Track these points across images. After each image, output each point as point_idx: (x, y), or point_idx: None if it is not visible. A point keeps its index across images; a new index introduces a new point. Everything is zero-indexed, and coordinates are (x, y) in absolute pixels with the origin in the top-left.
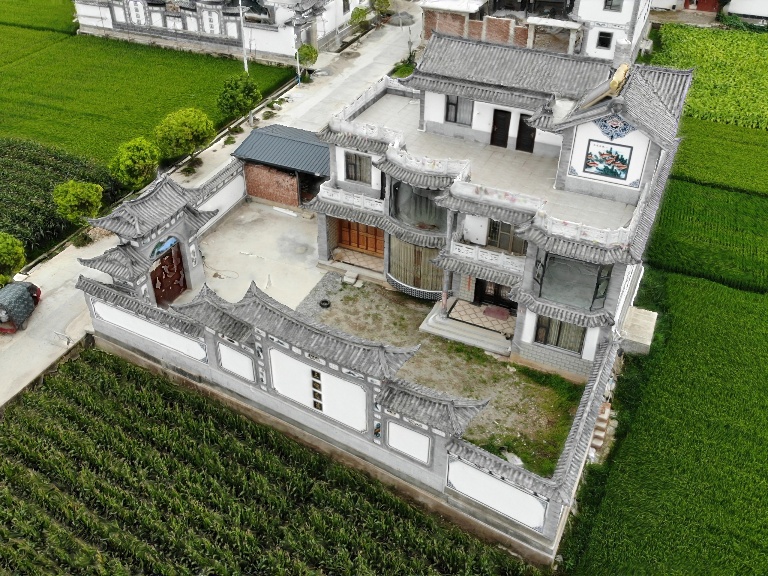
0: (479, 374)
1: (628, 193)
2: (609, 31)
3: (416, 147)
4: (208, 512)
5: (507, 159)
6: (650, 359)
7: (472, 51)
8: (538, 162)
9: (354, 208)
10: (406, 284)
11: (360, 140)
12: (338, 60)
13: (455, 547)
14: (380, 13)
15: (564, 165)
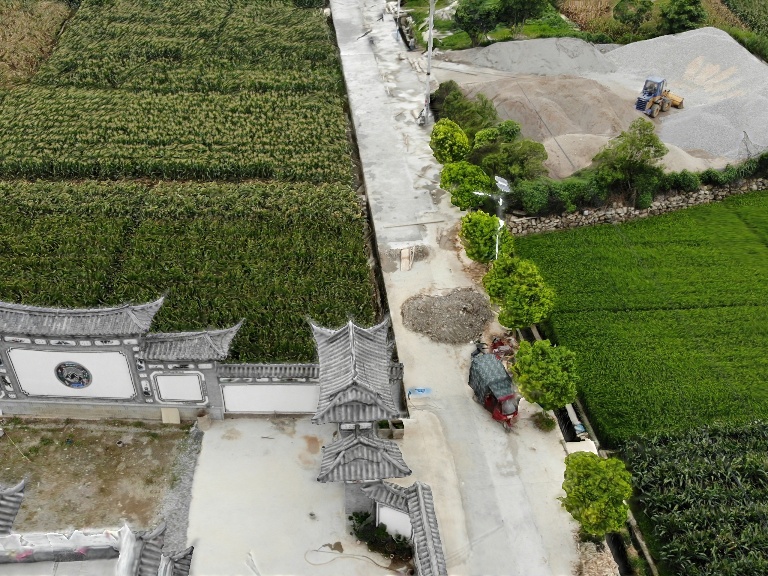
0: None
1: None
2: None
3: None
4: None
5: None
6: None
7: None
8: None
9: None
10: None
11: None
12: None
13: None
14: None
15: None
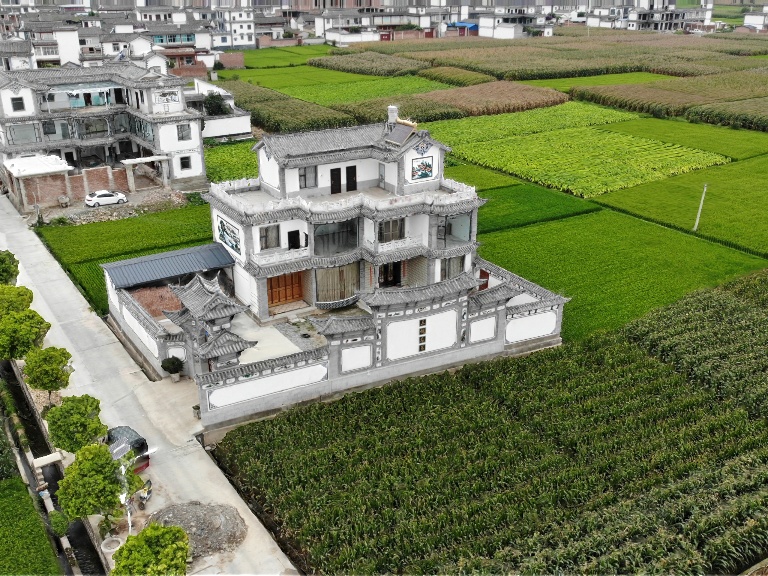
0: None
1: (434, 184)
2: (187, 155)
3: None
4: None
5: None
6: None
7: (296, 140)
8: (367, 192)
9: (288, 262)
10: (335, 301)
11: (272, 214)
12: None
13: None
14: None
15: (402, 180)
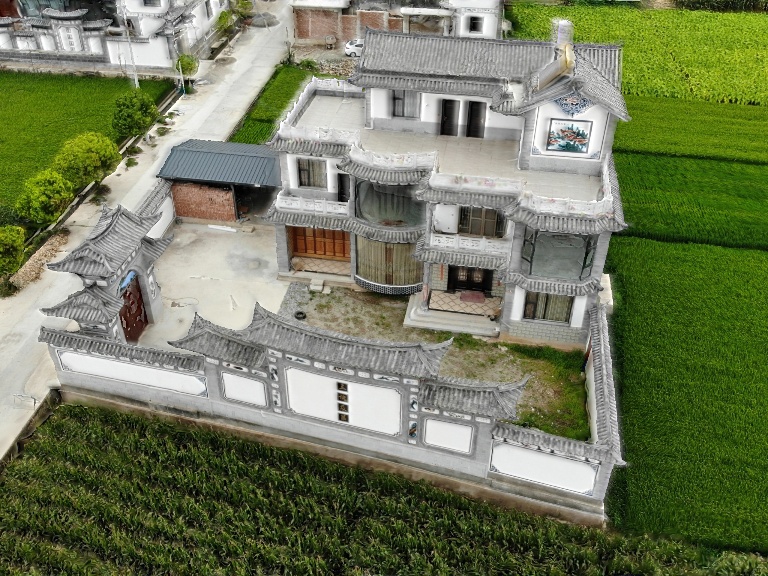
0: (475, 358)
1: (590, 165)
2: (480, 16)
3: (371, 145)
4: (267, 548)
5: (463, 147)
6: (616, 317)
7: (411, 44)
8: (492, 146)
9: (316, 214)
10: (378, 283)
11: (314, 145)
12: (215, 67)
13: (522, 527)
14: (240, 16)
15: (527, 146)
